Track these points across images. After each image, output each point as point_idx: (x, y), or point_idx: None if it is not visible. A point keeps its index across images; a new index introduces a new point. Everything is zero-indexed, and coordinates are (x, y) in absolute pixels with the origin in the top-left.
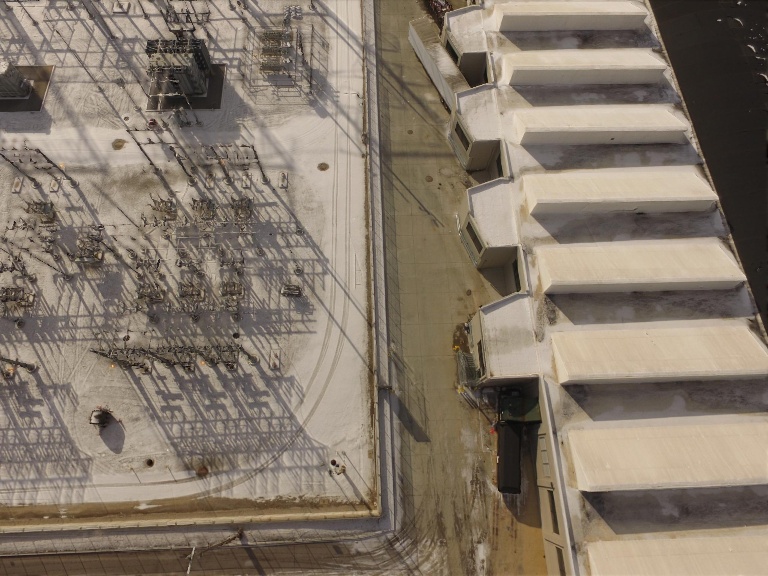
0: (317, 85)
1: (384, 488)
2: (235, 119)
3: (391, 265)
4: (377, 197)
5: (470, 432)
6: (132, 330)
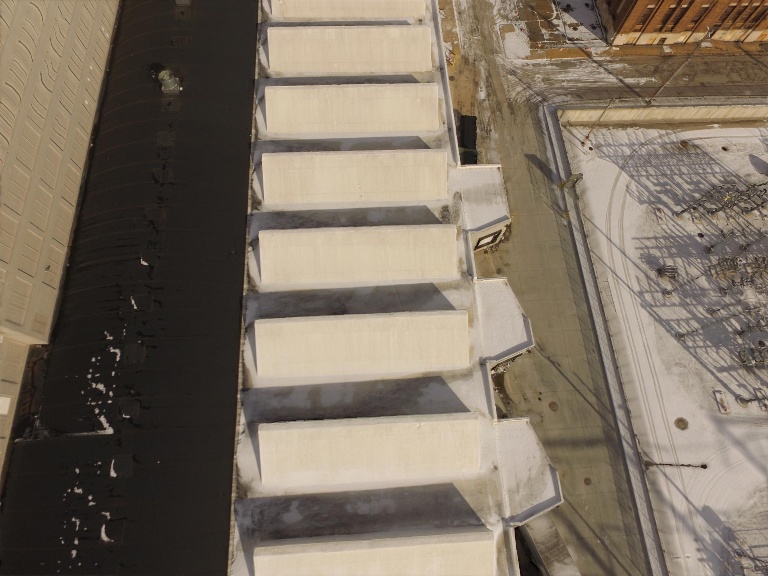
0: (735, 573)
1: (555, 127)
2: None
3: (580, 297)
4: (612, 376)
5: (493, 161)
6: None
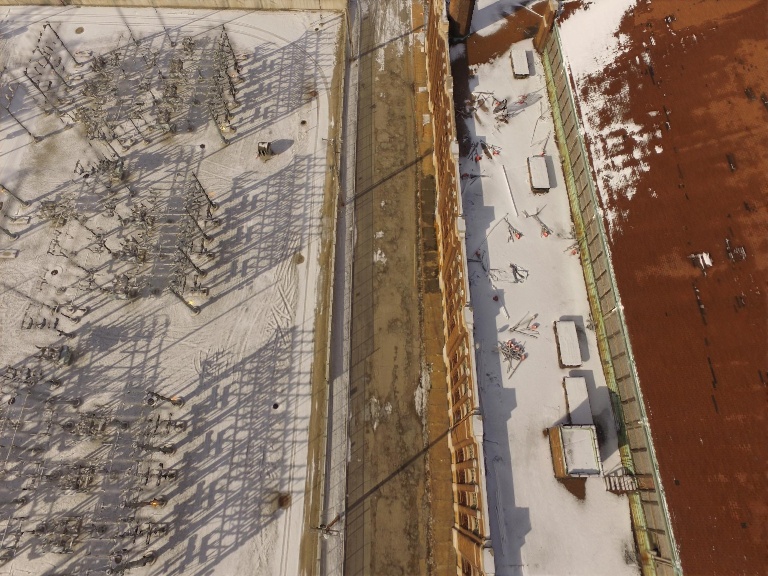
0: None
1: None
2: (0, 88)
3: None
4: None
5: None
6: (196, 143)
